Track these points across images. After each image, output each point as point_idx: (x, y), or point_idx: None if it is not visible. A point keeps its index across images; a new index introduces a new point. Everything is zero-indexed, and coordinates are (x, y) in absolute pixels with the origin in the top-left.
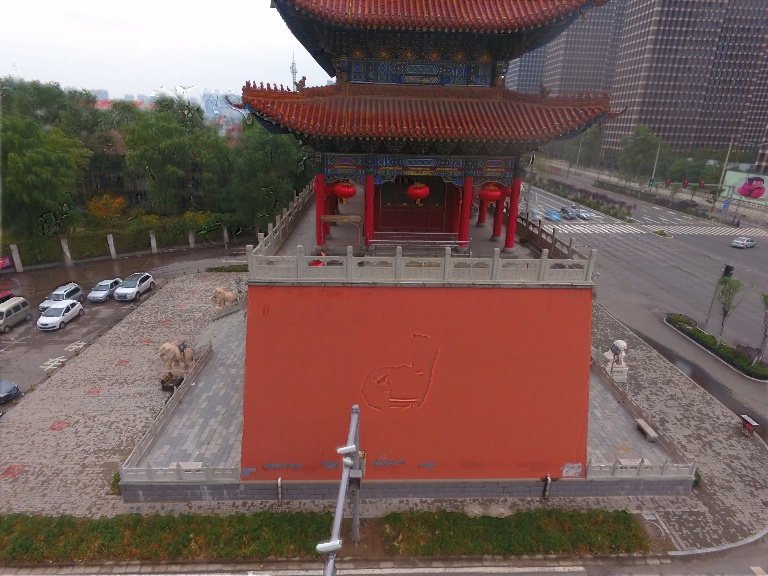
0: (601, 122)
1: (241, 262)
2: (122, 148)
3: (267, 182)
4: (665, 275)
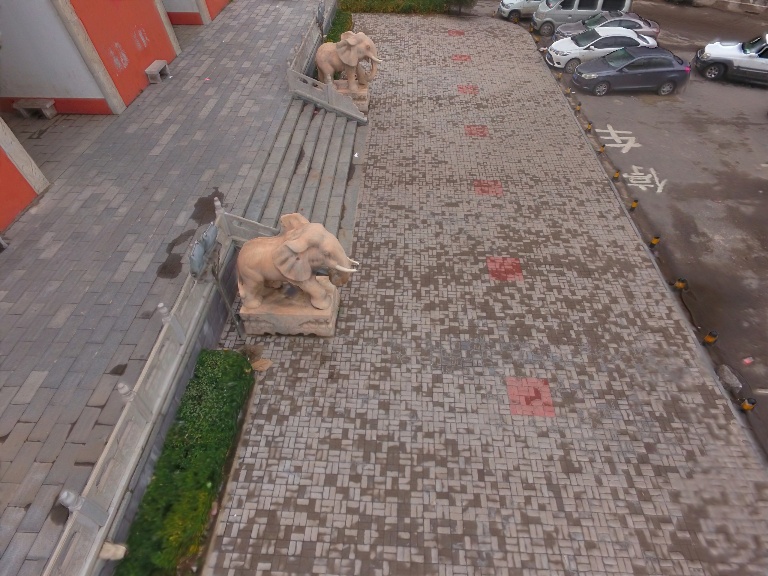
0: None
1: None
2: None
3: None
4: None
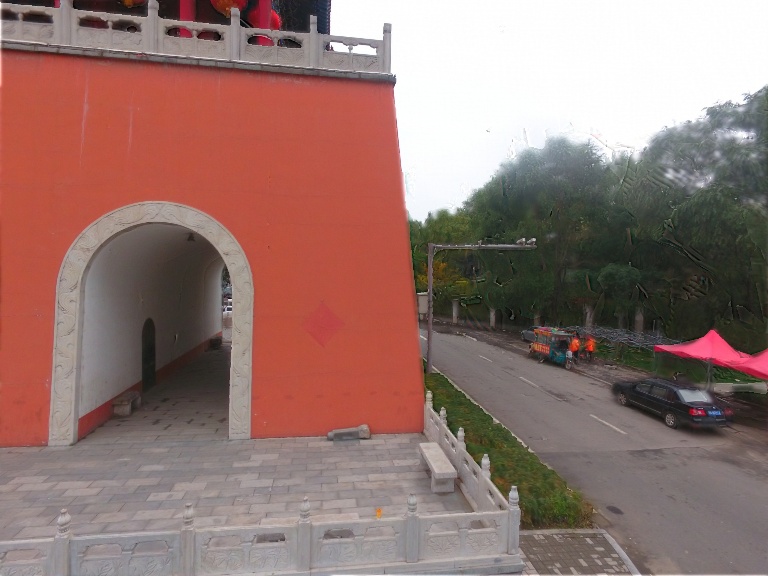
0: None
1: None
2: None
3: (488, 227)
4: None
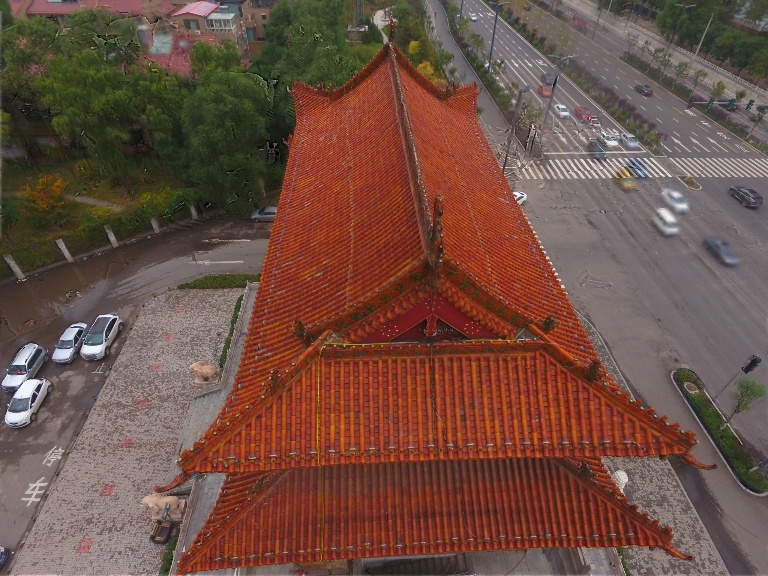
0: (654, 546)
1: (216, 264)
2: (44, 108)
3: (233, 166)
4: (683, 276)
